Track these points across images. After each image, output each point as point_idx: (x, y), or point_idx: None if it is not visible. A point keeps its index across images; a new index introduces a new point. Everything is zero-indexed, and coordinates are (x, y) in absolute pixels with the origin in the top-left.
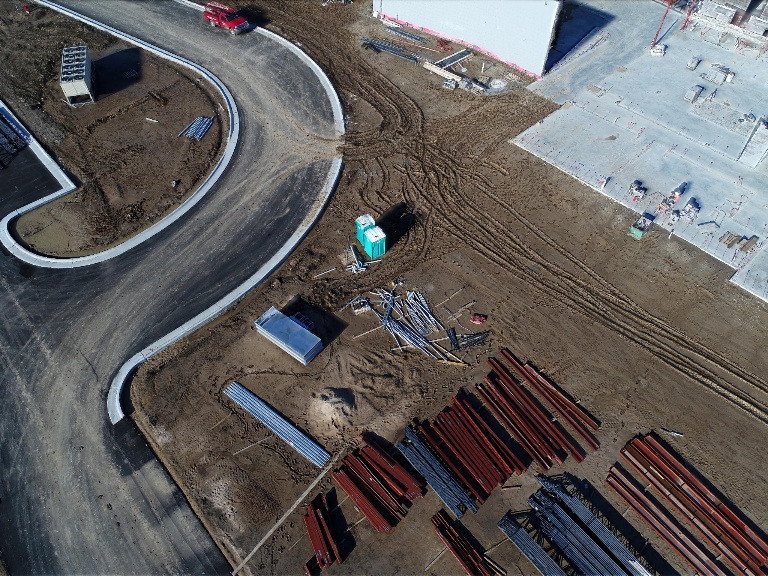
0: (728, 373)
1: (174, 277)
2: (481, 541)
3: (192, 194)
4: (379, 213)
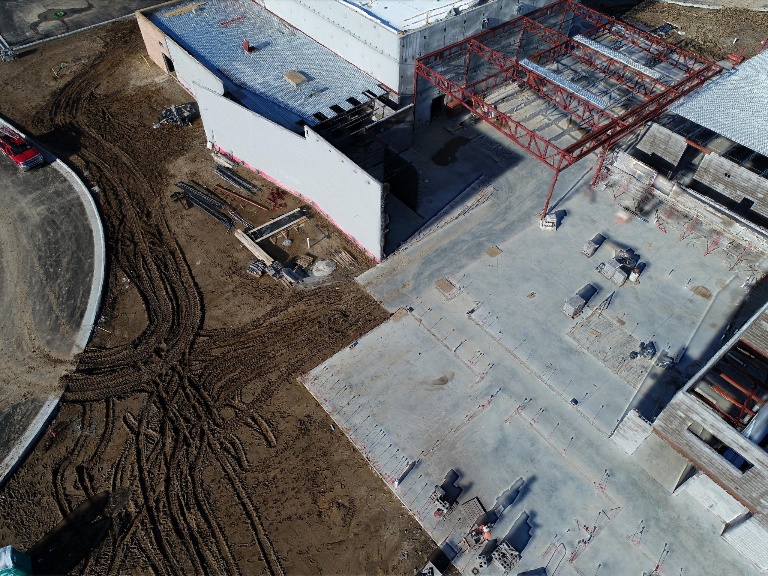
0: None
1: None
2: None
3: None
4: (63, 513)
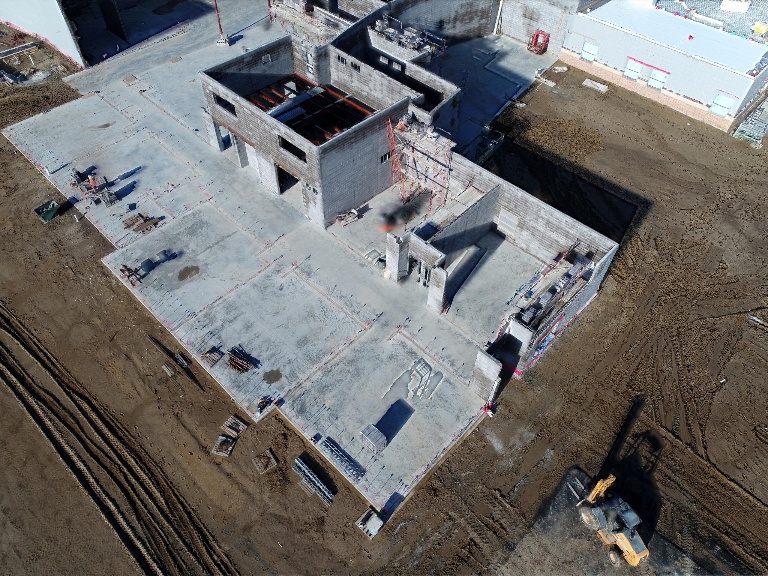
0: (23, 350)
1: None
2: None
3: None
4: None
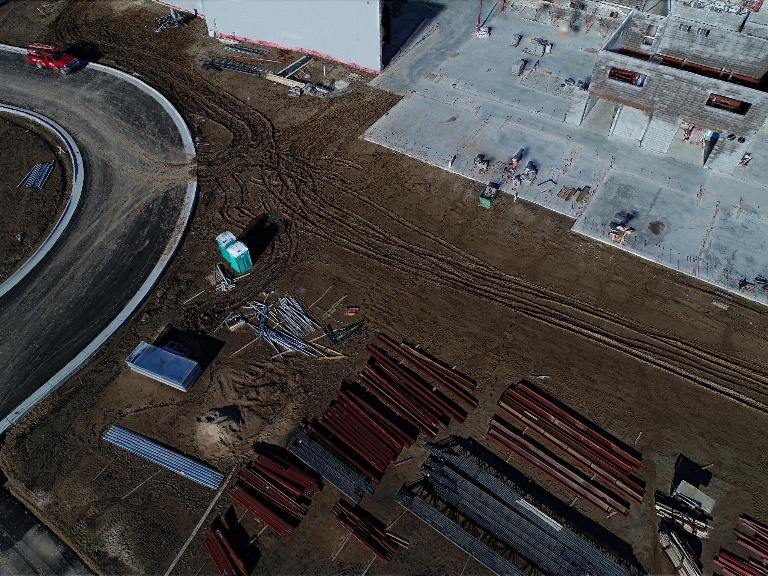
0: (580, 312)
1: (33, 333)
2: (381, 519)
3: (41, 244)
4: (242, 228)
